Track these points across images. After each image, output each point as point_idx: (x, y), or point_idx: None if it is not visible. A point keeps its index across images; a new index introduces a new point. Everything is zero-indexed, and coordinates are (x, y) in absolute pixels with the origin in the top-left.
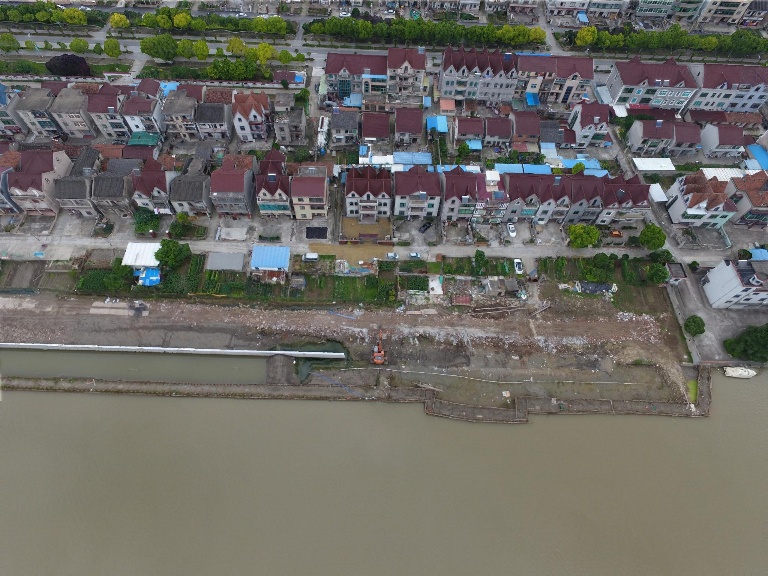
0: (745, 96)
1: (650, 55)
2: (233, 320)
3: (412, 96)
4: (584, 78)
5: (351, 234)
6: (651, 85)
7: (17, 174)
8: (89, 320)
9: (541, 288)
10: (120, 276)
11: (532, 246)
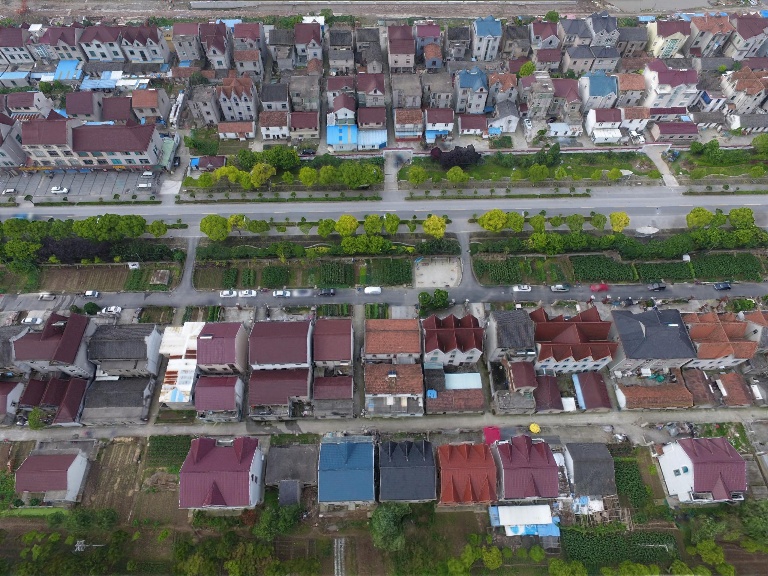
0: None
1: None
2: (256, 12)
3: None
4: None
5: (171, 44)
6: None
7: (406, 26)
8: (341, 11)
9: None
10: (323, 13)
11: None
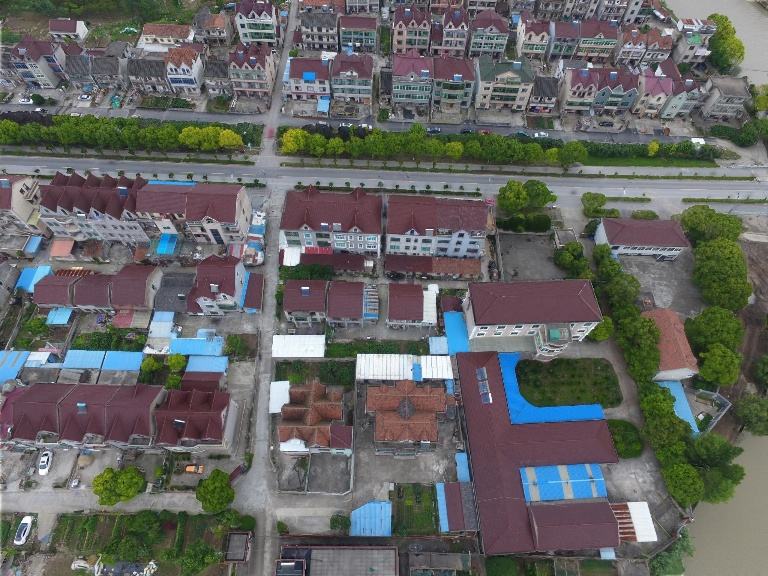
0: (451, 241)
1: (386, 161)
2: None
3: (17, 236)
4: (222, 222)
5: None
6: (317, 229)
7: None
8: None
9: (47, 566)
10: None
11: (64, 491)
